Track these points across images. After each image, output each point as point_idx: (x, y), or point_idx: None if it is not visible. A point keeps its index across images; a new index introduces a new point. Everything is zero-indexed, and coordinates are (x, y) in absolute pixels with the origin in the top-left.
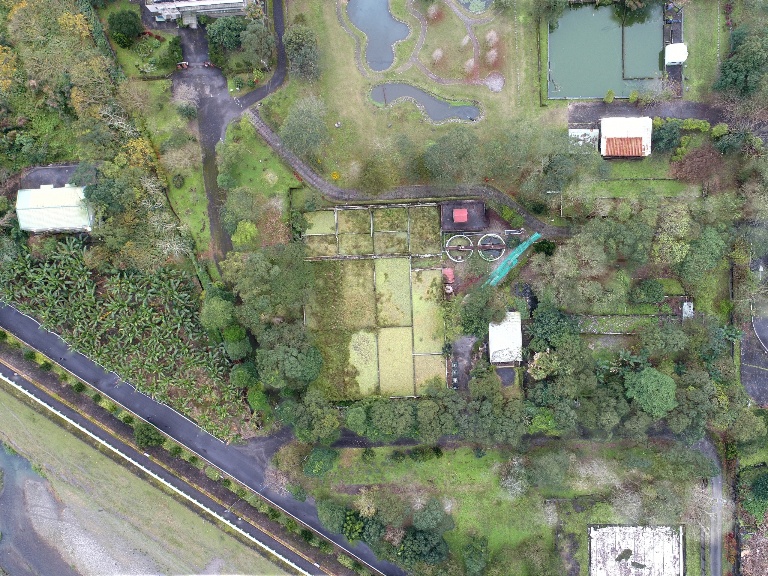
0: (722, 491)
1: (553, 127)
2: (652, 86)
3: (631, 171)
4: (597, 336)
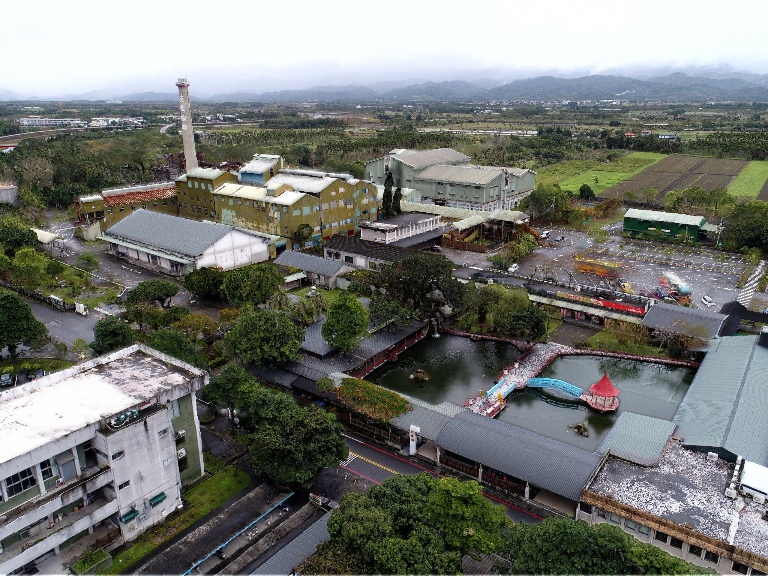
0: None
1: None
2: None
3: None
4: None
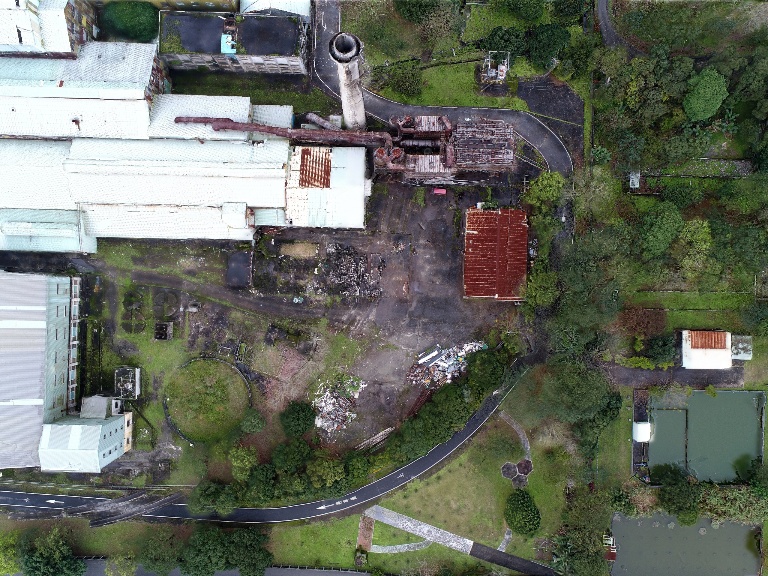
0: (598, 2)
1: (759, 363)
2: (661, 402)
3: (685, 318)
4: (718, 157)
